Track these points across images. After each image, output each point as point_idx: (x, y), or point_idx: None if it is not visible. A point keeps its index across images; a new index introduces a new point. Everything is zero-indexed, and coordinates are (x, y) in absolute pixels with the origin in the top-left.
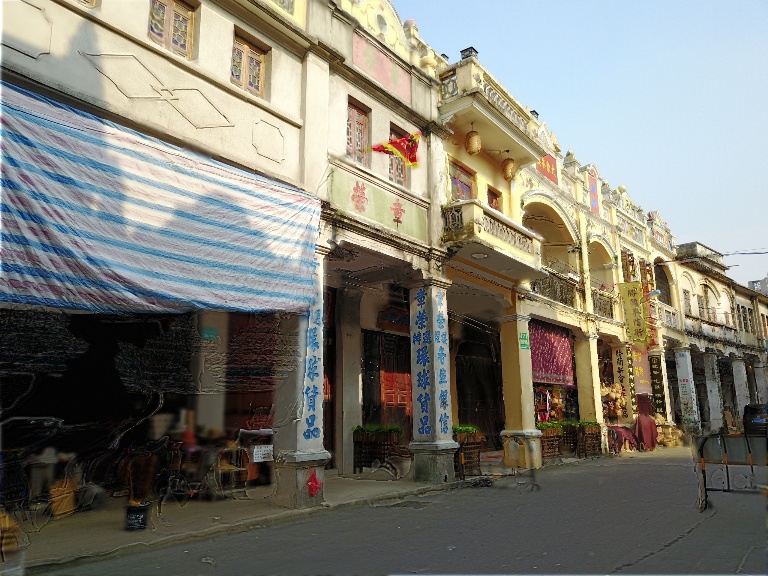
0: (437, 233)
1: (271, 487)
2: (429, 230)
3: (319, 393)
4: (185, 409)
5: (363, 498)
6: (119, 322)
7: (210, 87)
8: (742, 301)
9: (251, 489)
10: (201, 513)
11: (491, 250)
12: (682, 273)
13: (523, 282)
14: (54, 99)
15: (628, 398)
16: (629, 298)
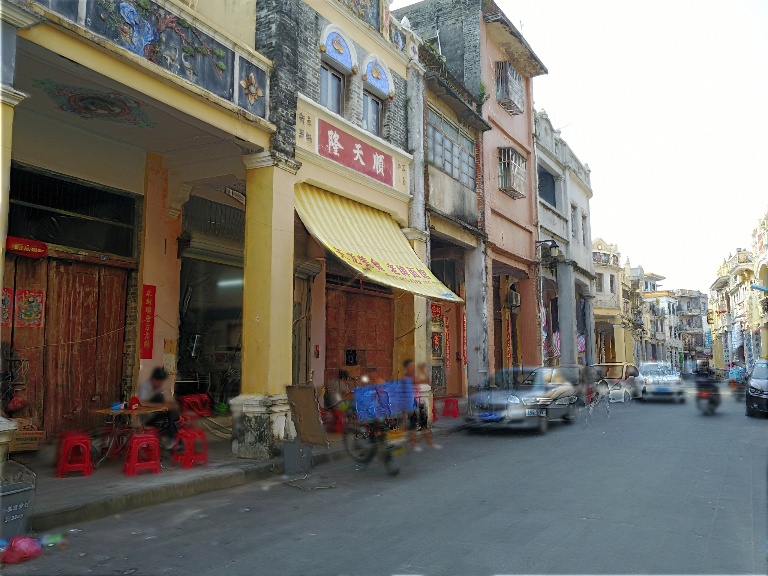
0: None
1: None
2: None
3: None
4: None
5: None
6: None
7: None
8: None
9: None
10: None
11: None
12: None
13: None
14: None
15: None
16: None
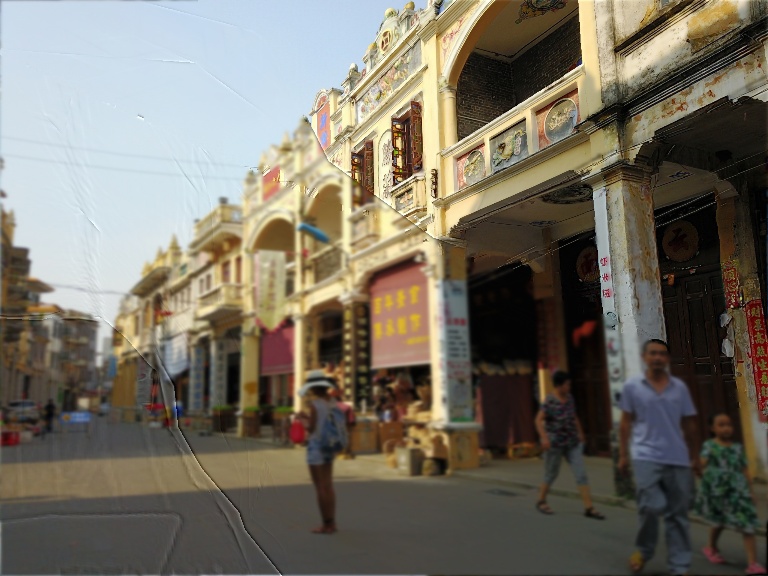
0: None
1: None
2: None
3: None
4: None
5: None
6: None
7: None
8: None
9: None
10: None
11: None
12: None
13: None
14: None
15: None
16: None
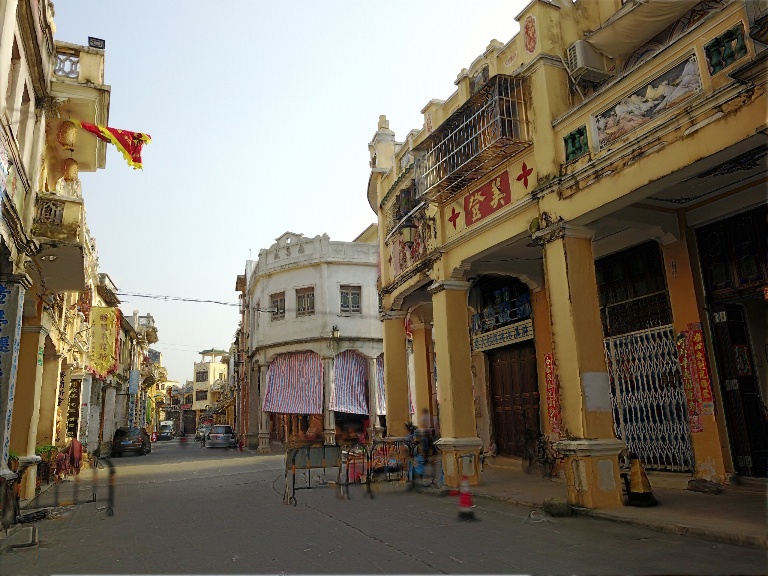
0: (30, 223)
1: None
2: (25, 217)
3: None
4: None
5: None
6: None
7: None
8: (121, 334)
9: None
10: None
11: (82, 258)
12: (97, 301)
13: (53, 292)
14: None
15: (63, 421)
16: (100, 322)
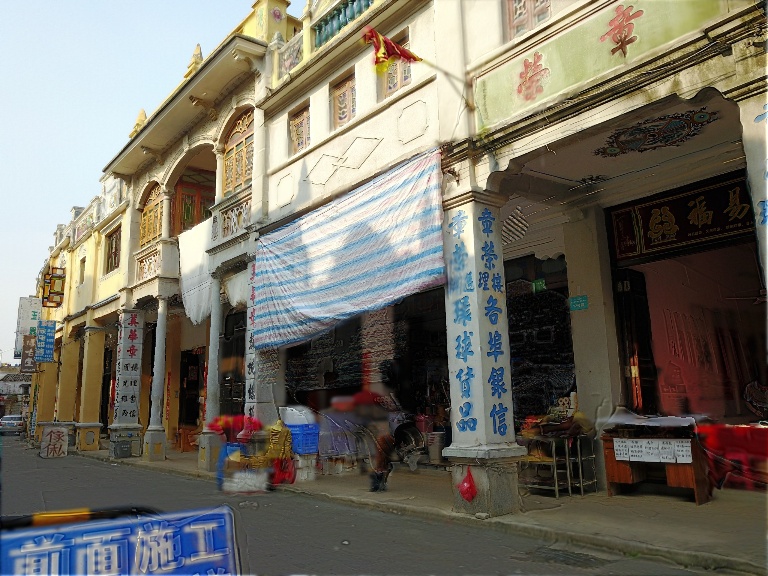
0: None
1: (658, 500)
2: None
3: (474, 375)
4: (324, 401)
5: (542, 526)
6: (295, 346)
7: (365, 125)
8: None
9: (623, 495)
10: (414, 491)
11: None
12: None
13: None
14: (286, 224)
15: None
16: None
